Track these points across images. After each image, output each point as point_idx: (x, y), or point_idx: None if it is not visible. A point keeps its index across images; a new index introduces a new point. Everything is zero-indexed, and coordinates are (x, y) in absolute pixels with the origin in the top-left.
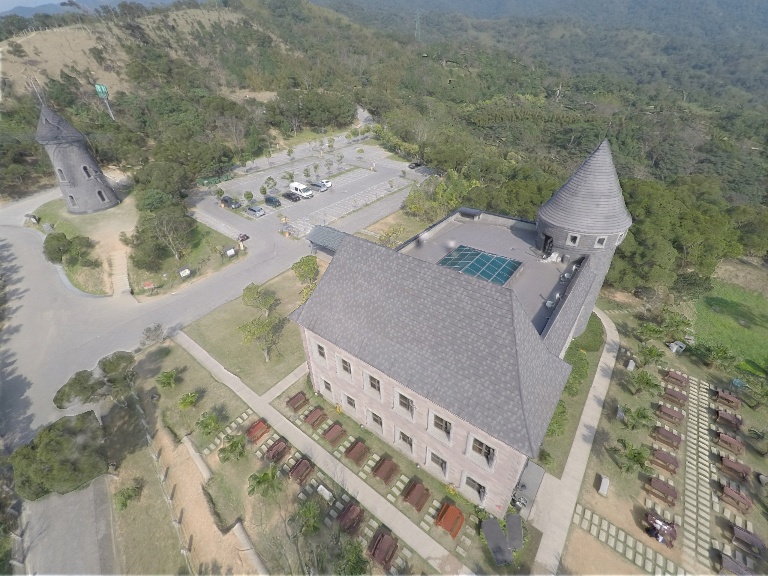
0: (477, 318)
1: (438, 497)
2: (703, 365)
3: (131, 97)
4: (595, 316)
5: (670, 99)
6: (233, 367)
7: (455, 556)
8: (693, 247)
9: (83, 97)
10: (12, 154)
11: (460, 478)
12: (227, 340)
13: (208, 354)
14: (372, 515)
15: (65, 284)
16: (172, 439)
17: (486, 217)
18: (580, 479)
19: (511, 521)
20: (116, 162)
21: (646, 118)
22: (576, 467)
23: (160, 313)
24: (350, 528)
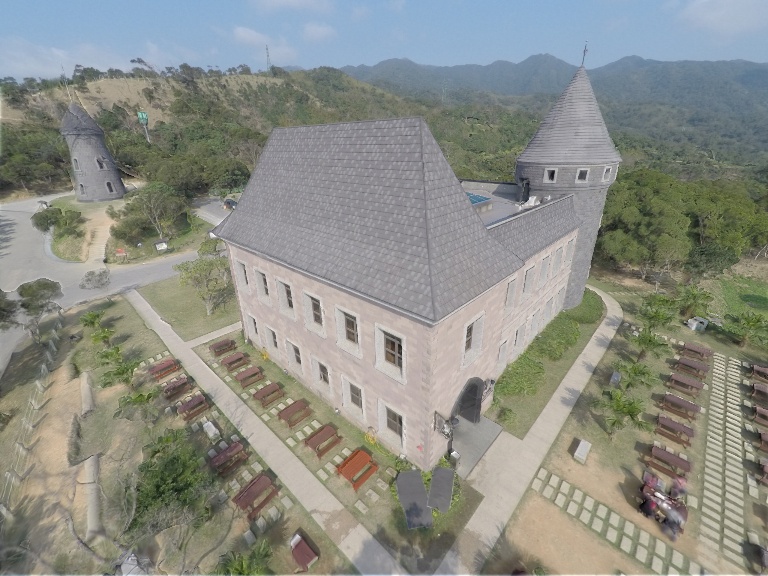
0: (385, 166)
1: (352, 445)
2: (733, 343)
3: (168, 125)
4: (594, 294)
5: (697, 156)
6: (170, 318)
7: (351, 512)
8: (710, 218)
9: (127, 124)
10: (46, 156)
11: (377, 413)
12: (176, 298)
13: (151, 307)
14: (259, 458)
15: (45, 251)
16: (71, 374)
17: (468, 185)
18: (550, 441)
19: (439, 475)
20: (134, 165)
21: (671, 166)
22: (547, 428)
23: (122, 276)
24: (225, 469)
